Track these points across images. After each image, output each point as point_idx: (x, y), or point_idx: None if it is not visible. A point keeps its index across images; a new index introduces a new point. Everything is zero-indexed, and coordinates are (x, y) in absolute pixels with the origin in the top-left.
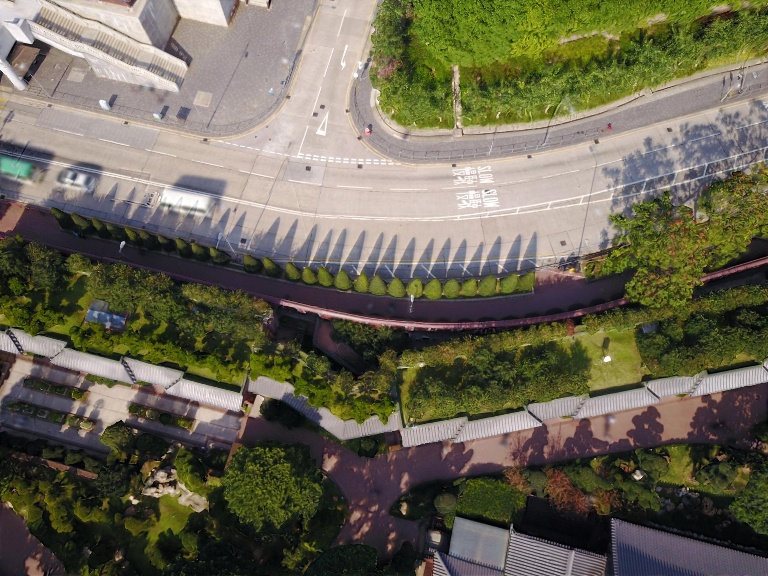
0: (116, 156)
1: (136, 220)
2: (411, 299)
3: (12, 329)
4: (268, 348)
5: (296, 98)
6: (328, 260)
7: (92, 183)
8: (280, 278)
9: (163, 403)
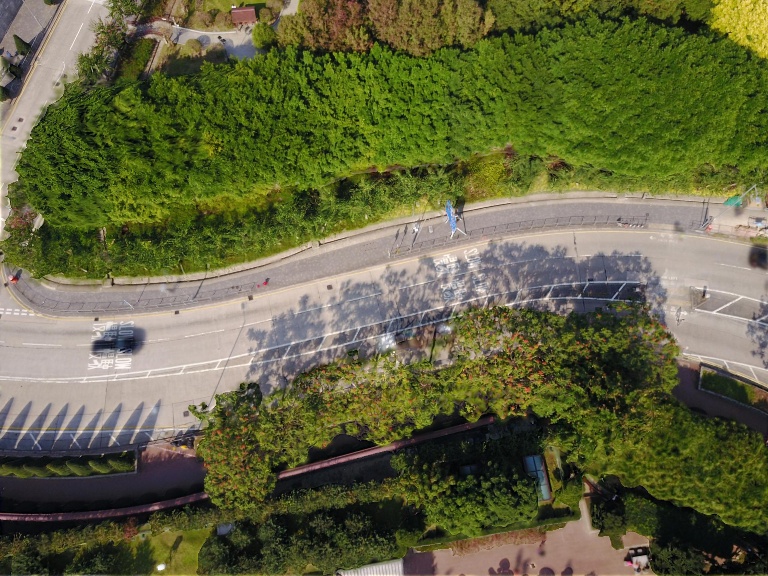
0: None
1: None
2: None
3: None
4: None
5: None
6: None
7: None
8: None
9: None
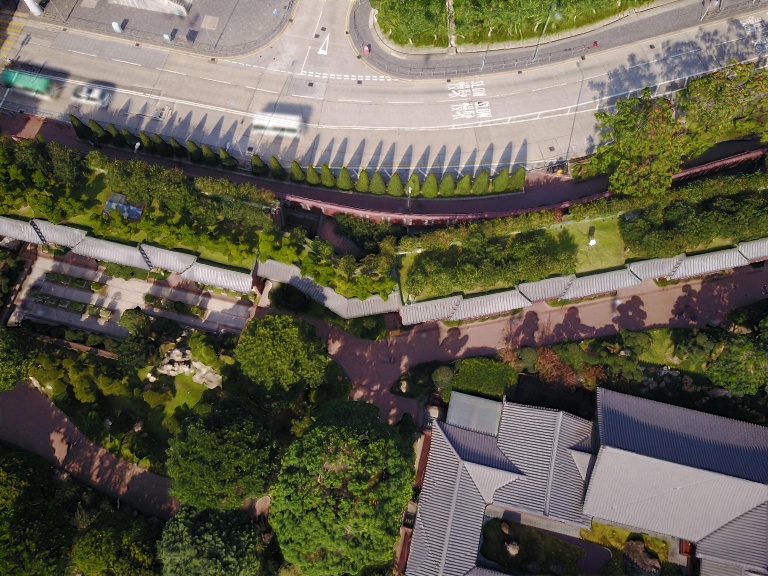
0: (128, 75)
1: (148, 132)
2: (409, 191)
3: (35, 220)
4: (276, 234)
5: (298, 21)
6: (330, 165)
7: (106, 99)
8: (285, 181)
9: (177, 295)
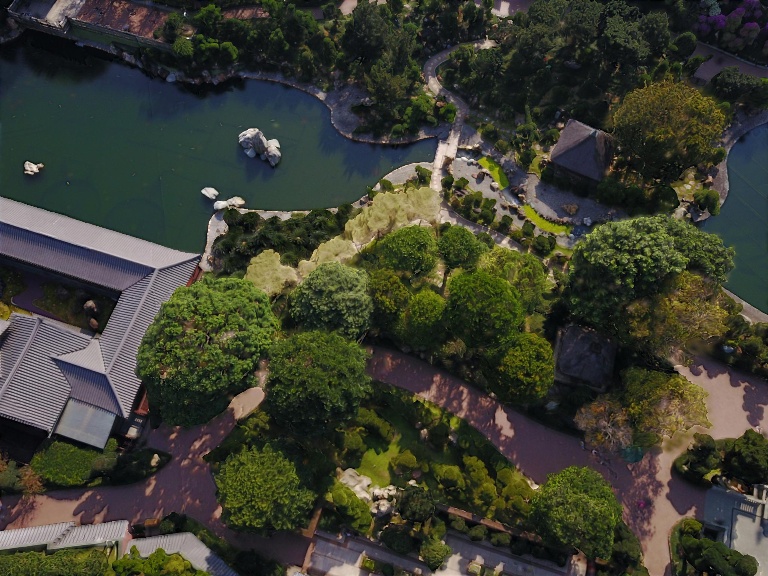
0: None
1: None
2: None
3: None
4: None
5: None
6: None
7: None
8: None
9: None
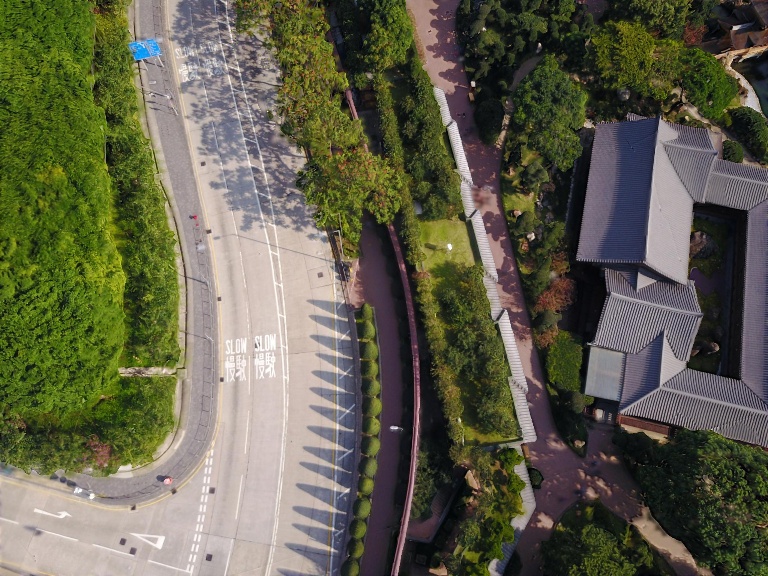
0: None
1: None
2: (395, 429)
3: None
4: None
5: None
6: (331, 528)
7: None
8: None
9: None
